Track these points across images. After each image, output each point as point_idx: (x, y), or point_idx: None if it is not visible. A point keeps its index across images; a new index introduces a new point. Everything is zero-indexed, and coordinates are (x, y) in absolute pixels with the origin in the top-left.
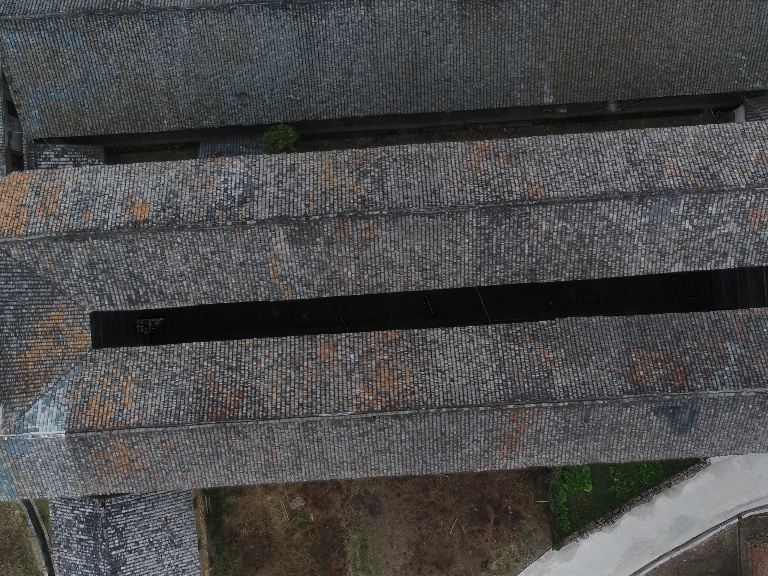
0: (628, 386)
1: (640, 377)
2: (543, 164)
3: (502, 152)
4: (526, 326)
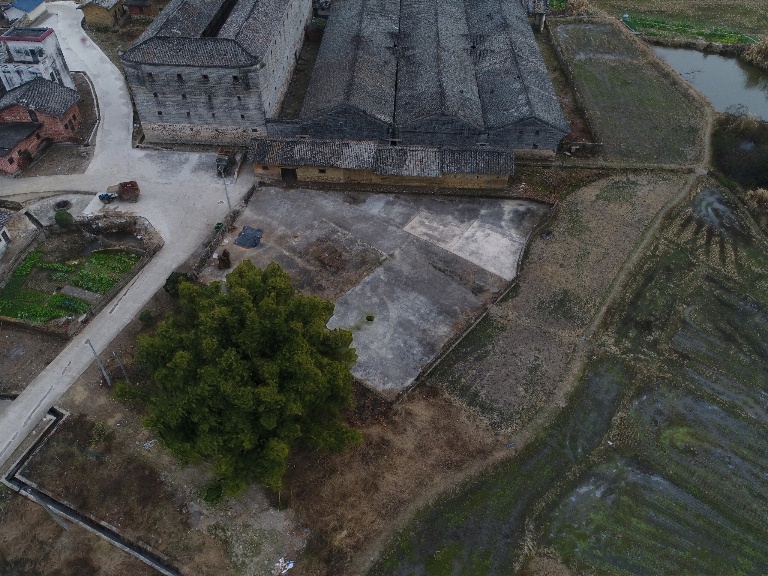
0: (188, 3)
1: (190, 6)
2: (275, 2)
3: (283, 0)
4: (221, 3)
